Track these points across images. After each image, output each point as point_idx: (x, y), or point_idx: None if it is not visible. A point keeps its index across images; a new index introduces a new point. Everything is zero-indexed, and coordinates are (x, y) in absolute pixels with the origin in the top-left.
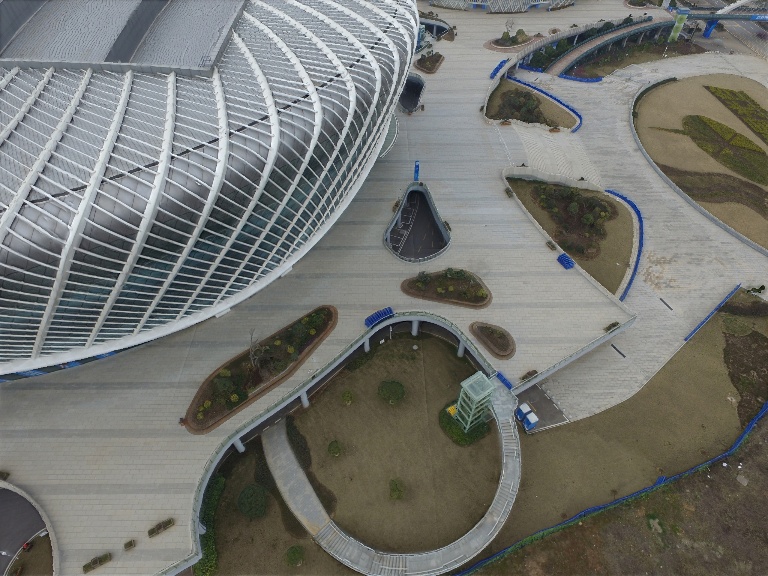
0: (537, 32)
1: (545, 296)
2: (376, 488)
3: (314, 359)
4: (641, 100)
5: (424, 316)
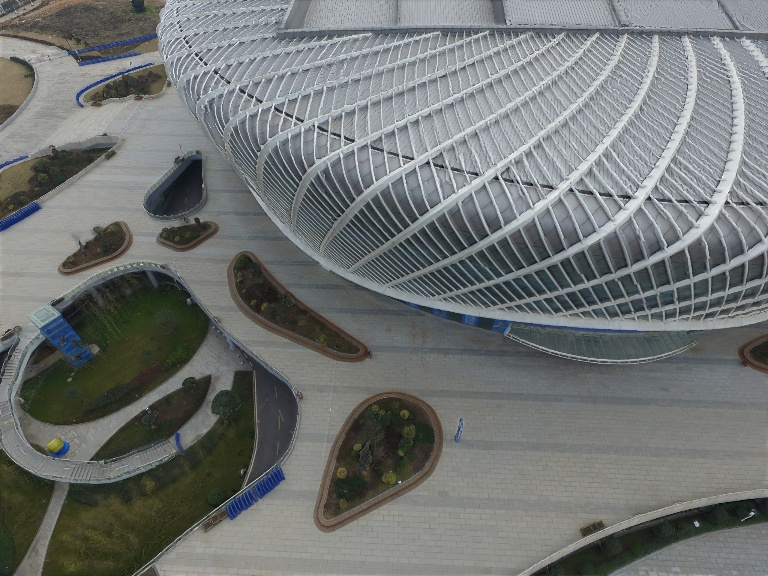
0: None
1: None
2: None
3: None
4: None
5: None
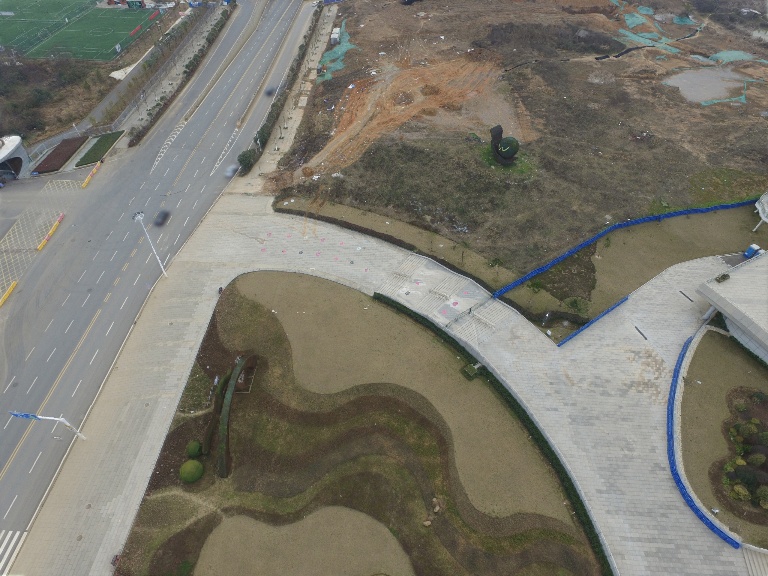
0: None
1: None
2: None
3: None
4: None
5: None
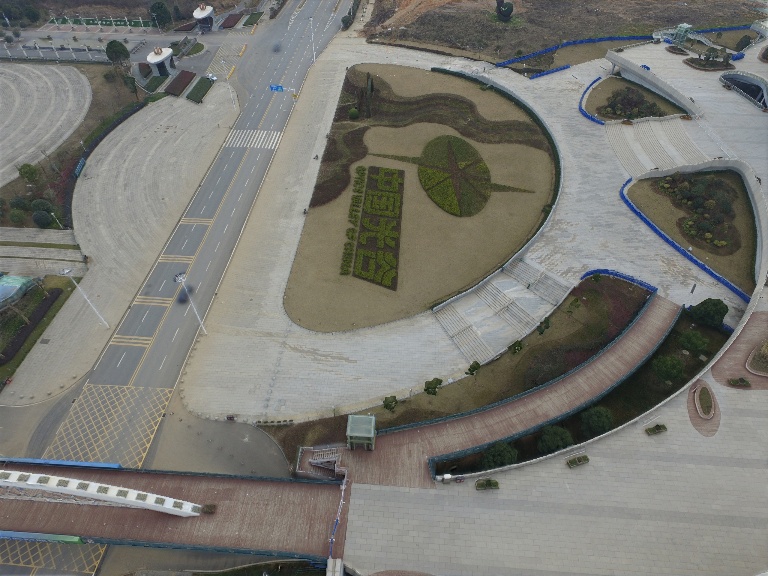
0: (749, 408)
1: (654, 61)
2: (699, 49)
3: (758, 38)
4: (525, 242)
5: (715, 58)
